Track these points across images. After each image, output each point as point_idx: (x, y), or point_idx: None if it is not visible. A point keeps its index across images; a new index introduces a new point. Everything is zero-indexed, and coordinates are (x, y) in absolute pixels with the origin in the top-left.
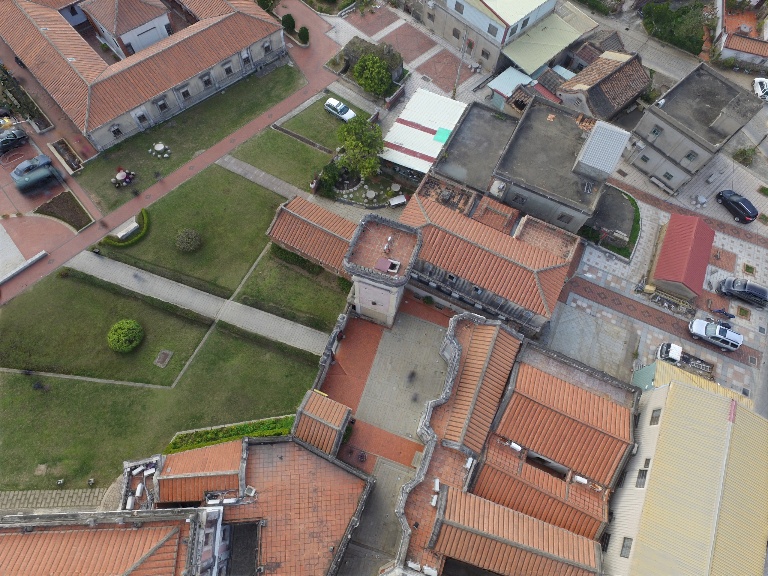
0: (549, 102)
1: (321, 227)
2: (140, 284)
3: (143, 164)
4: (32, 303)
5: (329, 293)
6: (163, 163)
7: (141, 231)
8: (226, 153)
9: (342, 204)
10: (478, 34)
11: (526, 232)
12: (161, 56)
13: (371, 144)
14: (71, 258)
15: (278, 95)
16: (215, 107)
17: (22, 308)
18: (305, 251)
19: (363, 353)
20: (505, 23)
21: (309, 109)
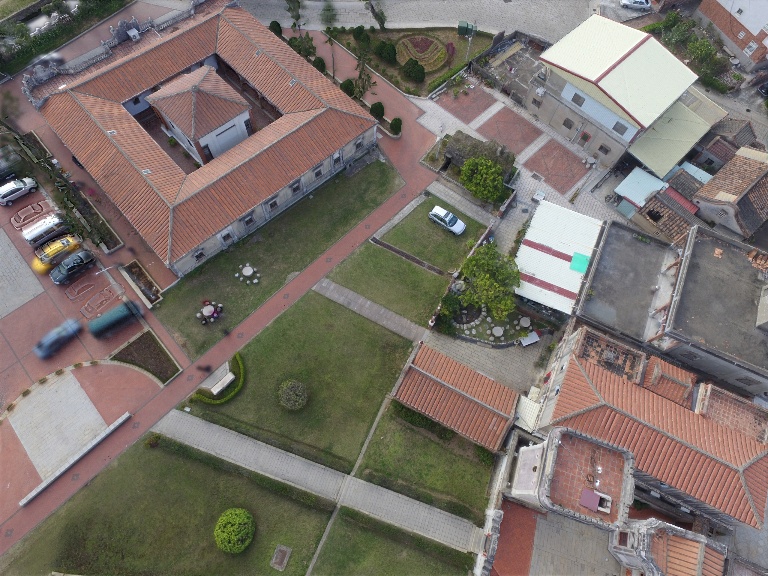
0: (715, 234)
1: (459, 391)
2: (243, 454)
3: (230, 292)
4: (119, 483)
5: (466, 465)
6: (253, 290)
7: (238, 383)
8: (323, 276)
9: (464, 342)
10: (599, 129)
11: (710, 405)
12: (248, 166)
13: (507, 283)
14: (159, 420)
15: (373, 199)
16: (304, 216)
17: (108, 490)
18: (440, 419)
19: (518, 549)
20: (640, 124)
21: (410, 217)
